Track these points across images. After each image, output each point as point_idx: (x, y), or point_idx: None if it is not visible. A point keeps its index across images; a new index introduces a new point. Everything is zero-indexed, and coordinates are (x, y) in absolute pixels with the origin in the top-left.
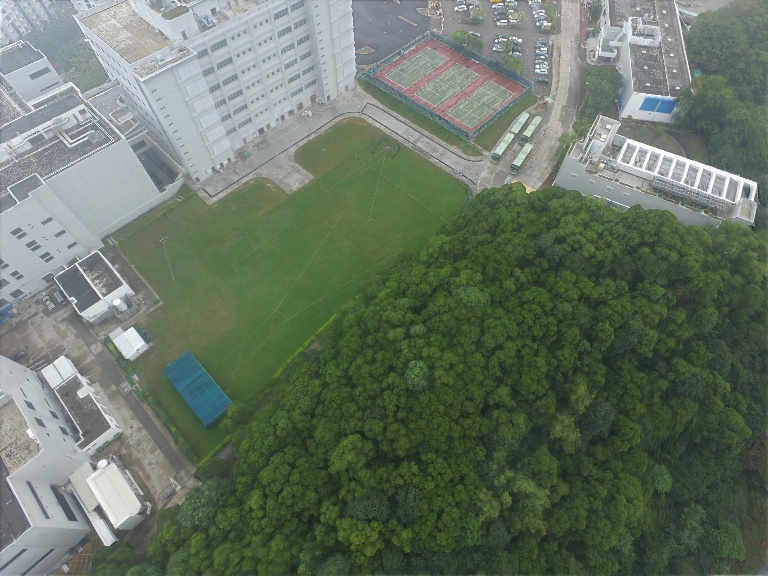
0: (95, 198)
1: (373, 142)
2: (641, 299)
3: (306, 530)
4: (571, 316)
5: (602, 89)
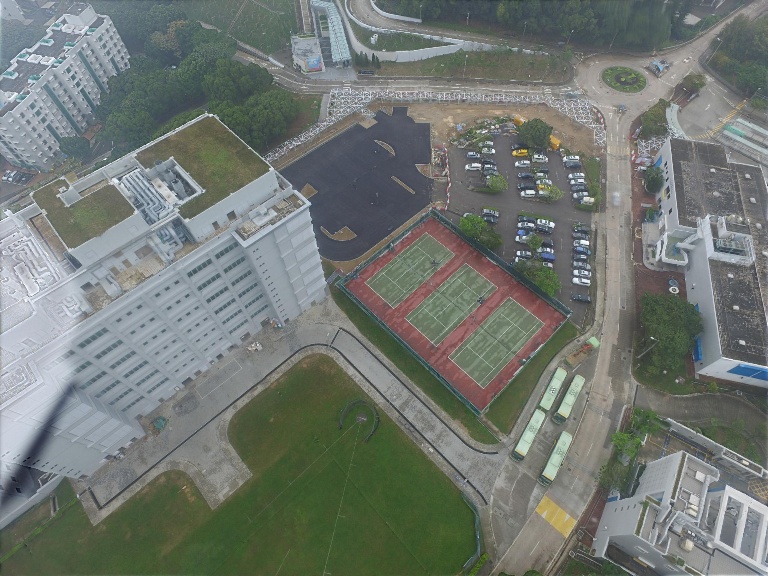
0: None
1: (342, 407)
2: None
3: None
4: None
5: (675, 349)
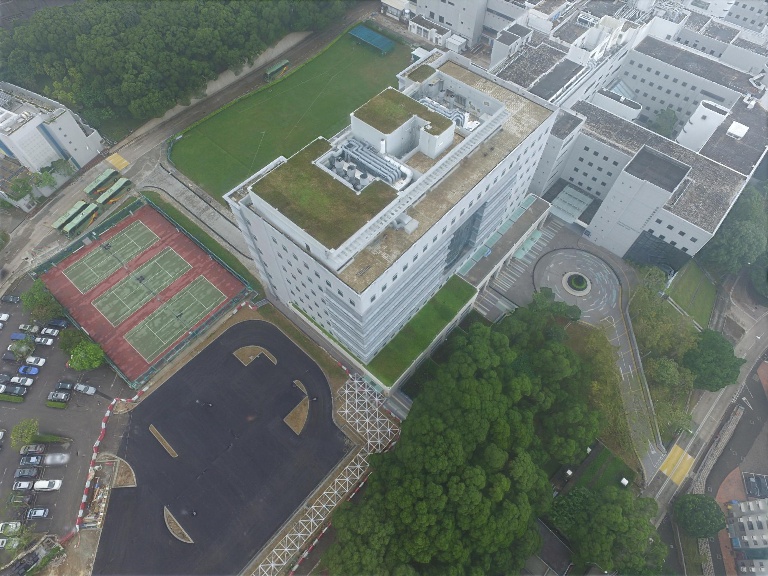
0: None
1: None
2: (91, 5)
3: None
4: None
5: None
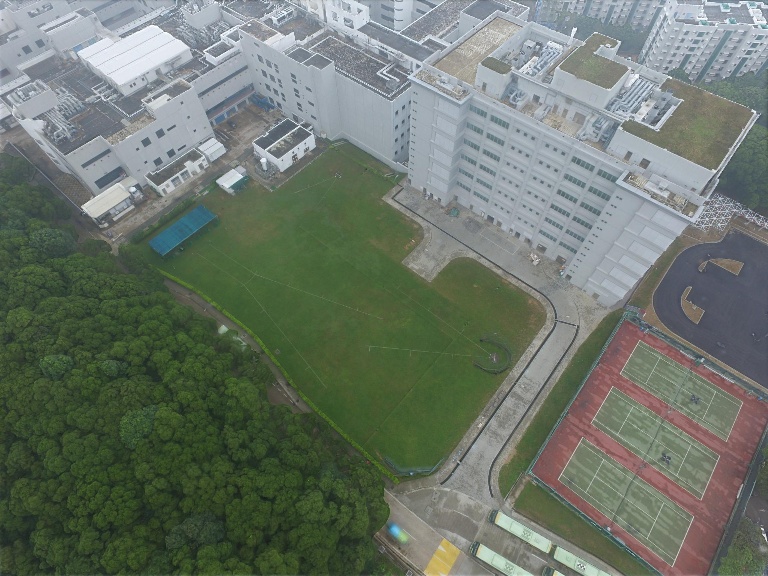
0: (354, 113)
1: (501, 339)
2: None
3: (0, 307)
4: (80, 552)
5: None
